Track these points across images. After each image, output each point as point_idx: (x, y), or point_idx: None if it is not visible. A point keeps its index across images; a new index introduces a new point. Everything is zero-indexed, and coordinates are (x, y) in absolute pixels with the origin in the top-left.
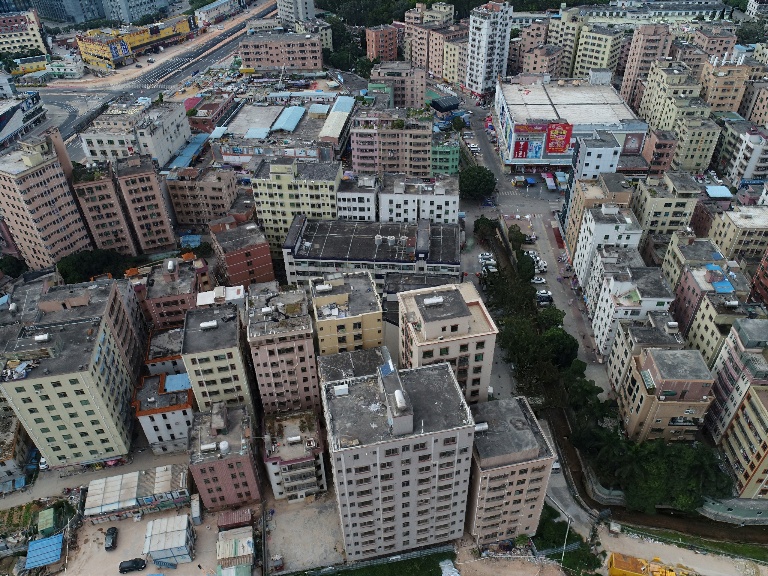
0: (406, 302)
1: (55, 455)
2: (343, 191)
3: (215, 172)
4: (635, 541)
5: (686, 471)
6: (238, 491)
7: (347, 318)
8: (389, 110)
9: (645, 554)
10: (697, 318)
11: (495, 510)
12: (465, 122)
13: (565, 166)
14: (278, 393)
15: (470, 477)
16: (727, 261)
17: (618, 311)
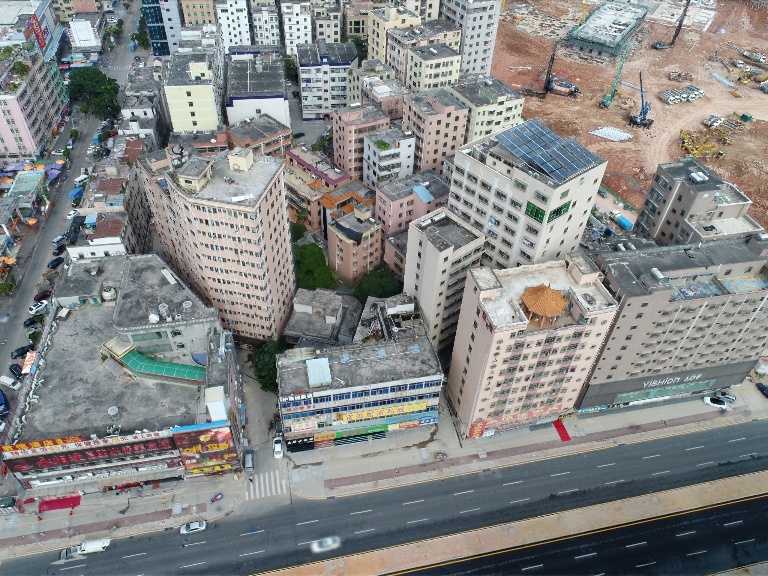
0: None
1: None
2: None
3: (114, 166)
4: None
5: None
6: None
7: None
8: None
9: None
10: (313, 2)
11: None
12: None
13: None
14: None
15: None
16: None
17: None
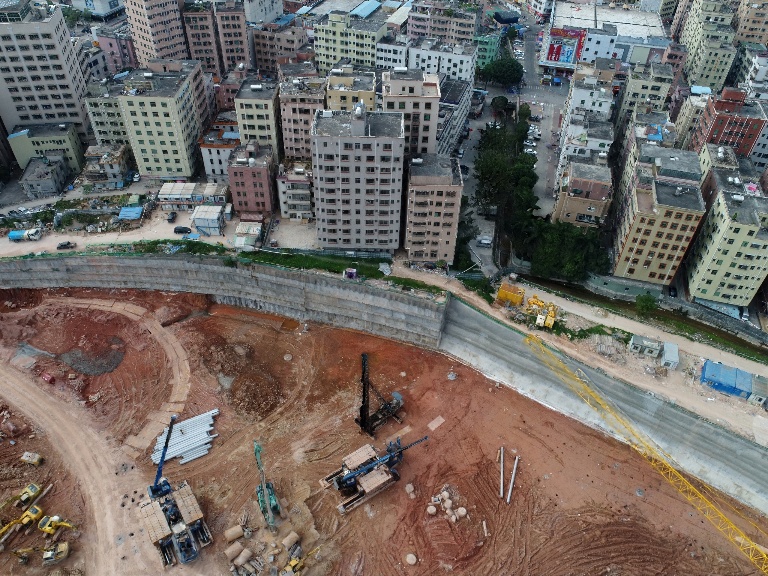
0: (387, 79)
1: (145, 166)
2: (383, 44)
3: (291, 28)
4: (526, 288)
5: (573, 243)
6: (257, 200)
7: (348, 91)
8: (445, 2)
9: (530, 295)
10: (628, 159)
11: (421, 227)
12: (519, 33)
13: None
14: (296, 148)
15: (404, 193)
16: (667, 122)
17: (569, 148)
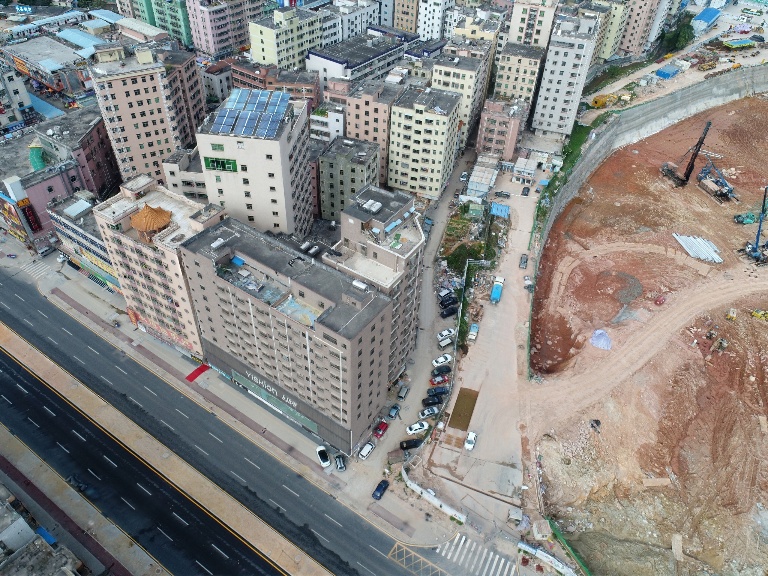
0: None
1: (441, 184)
2: None
3: None
4: None
5: None
6: None
7: None
8: None
9: (592, 100)
10: None
11: None
12: None
13: (316, 8)
14: None
15: None
16: None
17: None
